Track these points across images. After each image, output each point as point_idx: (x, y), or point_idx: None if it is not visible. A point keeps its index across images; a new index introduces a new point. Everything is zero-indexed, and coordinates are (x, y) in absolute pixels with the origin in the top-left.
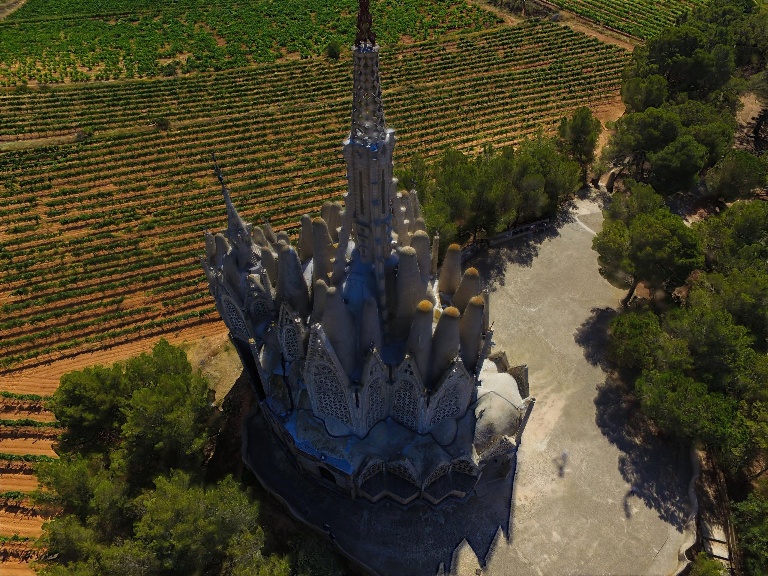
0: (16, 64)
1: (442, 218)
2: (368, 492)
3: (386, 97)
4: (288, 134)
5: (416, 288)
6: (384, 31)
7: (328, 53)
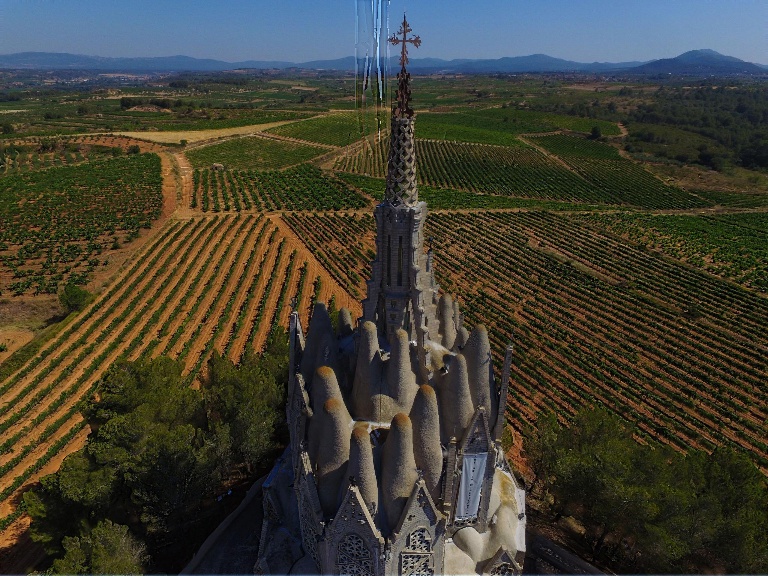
0: (667, 236)
1: (655, 507)
2: (259, 525)
3: None
4: None
5: (363, 375)
6: None
7: None
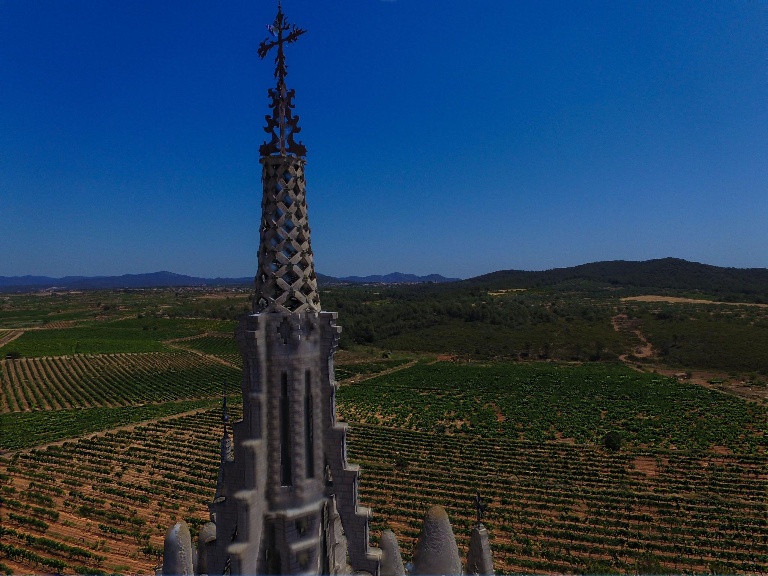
0: (340, 405)
1: None
2: None
3: (669, 501)
4: (518, 508)
5: None
6: (688, 437)
7: (605, 443)
